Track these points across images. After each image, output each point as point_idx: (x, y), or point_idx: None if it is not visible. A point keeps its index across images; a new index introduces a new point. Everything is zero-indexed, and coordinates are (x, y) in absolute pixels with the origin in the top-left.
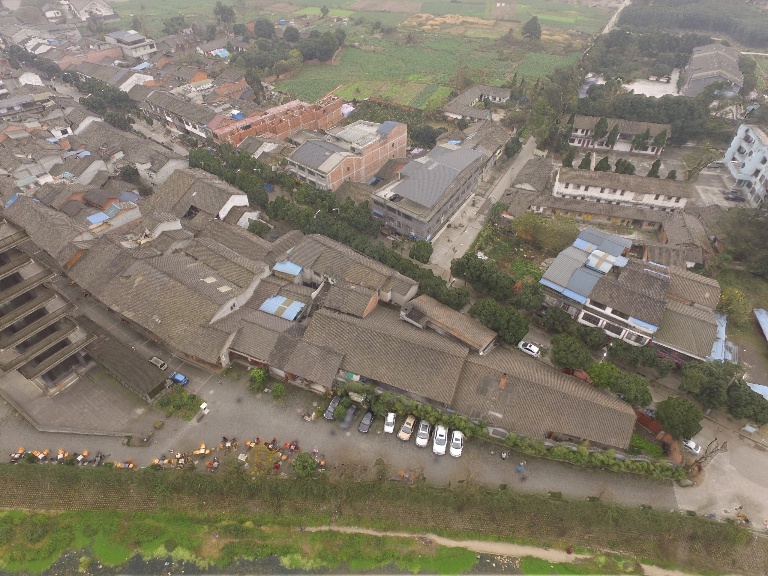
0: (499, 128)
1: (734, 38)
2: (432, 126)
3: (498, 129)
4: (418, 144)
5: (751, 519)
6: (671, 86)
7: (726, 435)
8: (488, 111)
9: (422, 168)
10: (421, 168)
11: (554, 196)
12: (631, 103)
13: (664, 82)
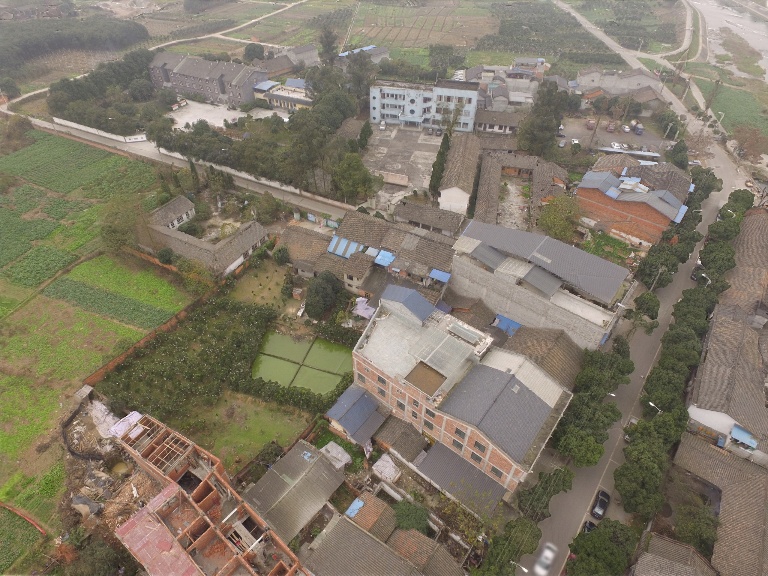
0: (350, 213)
1: (90, 49)
2: (247, 296)
3: (353, 214)
4: (337, 309)
5: (764, 204)
6: (196, 105)
7: (709, 198)
8: (257, 223)
9: (550, 268)
10: (550, 269)
11: (476, 208)
12: (326, 118)
13: (184, 105)
